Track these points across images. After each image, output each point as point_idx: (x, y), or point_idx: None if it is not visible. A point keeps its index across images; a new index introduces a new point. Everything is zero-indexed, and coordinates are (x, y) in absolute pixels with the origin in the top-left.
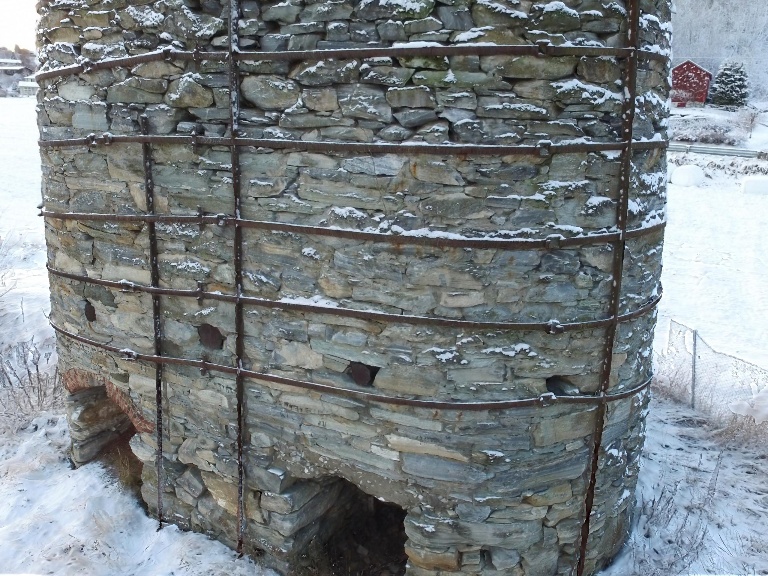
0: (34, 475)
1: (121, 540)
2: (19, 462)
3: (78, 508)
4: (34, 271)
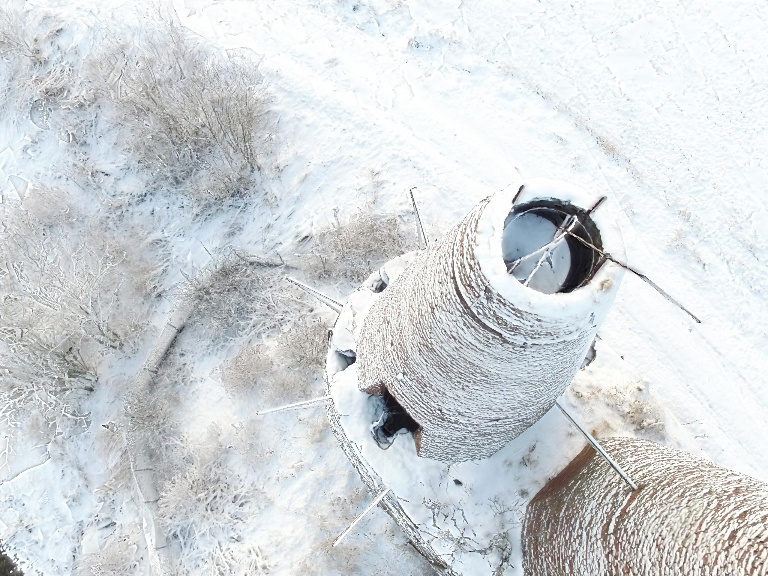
0: (321, 437)
1: (362, 504)
2: (313, 417)
3: (343, 476)
4: (280, 3)
